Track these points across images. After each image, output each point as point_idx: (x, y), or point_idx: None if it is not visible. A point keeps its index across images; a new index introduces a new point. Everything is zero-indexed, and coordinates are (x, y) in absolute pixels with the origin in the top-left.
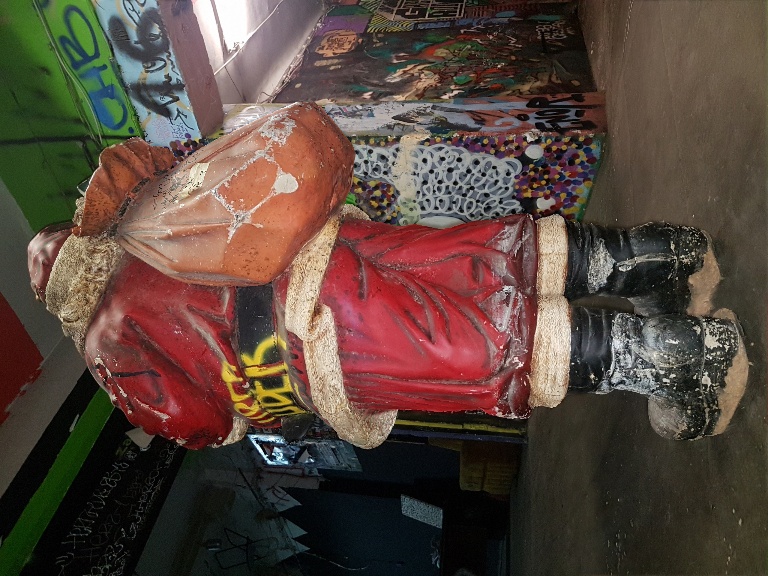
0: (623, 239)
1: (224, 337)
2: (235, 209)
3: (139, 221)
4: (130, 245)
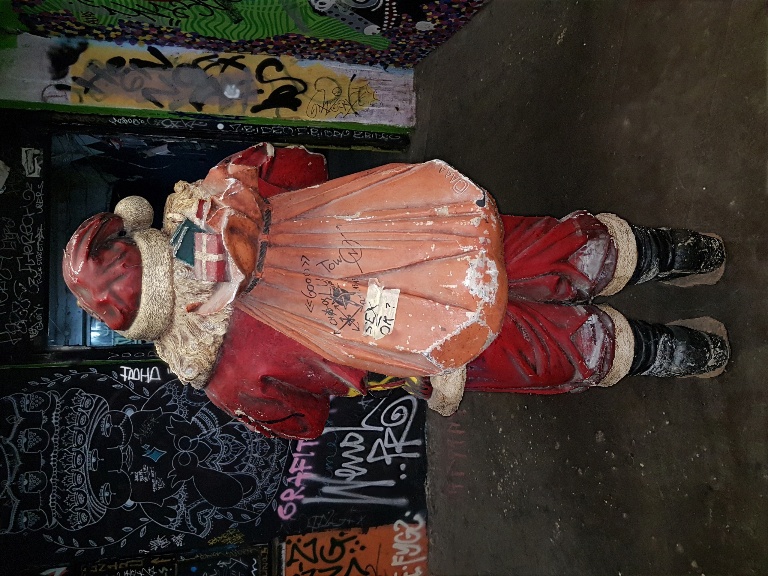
0: (672, 257)
1: (361, 380)
2: (445, 367)
3: (286, 316)
4: (259, 318)
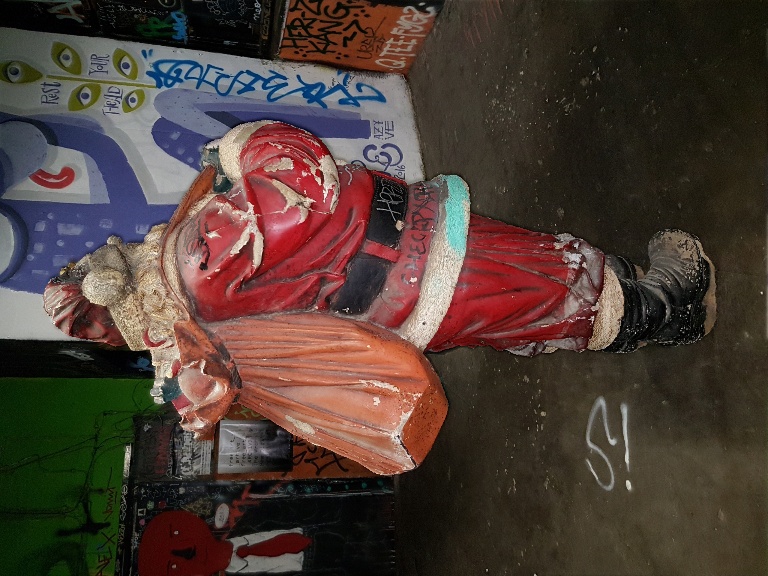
0: None
1: None
2: None
3: None
4: None
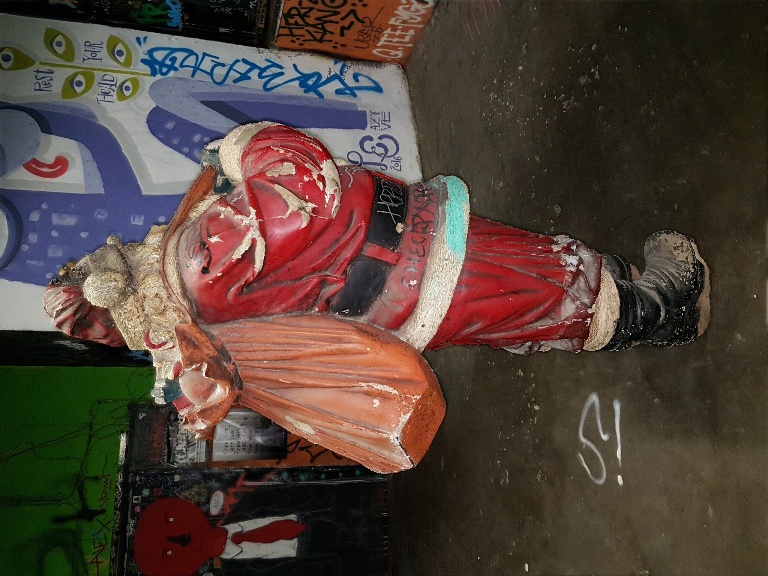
0: None
1: None
2: None
3: None
4: None
